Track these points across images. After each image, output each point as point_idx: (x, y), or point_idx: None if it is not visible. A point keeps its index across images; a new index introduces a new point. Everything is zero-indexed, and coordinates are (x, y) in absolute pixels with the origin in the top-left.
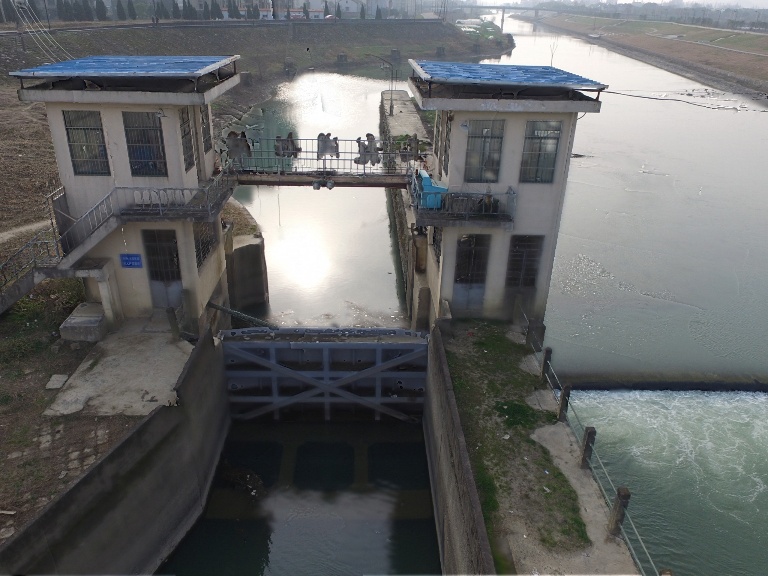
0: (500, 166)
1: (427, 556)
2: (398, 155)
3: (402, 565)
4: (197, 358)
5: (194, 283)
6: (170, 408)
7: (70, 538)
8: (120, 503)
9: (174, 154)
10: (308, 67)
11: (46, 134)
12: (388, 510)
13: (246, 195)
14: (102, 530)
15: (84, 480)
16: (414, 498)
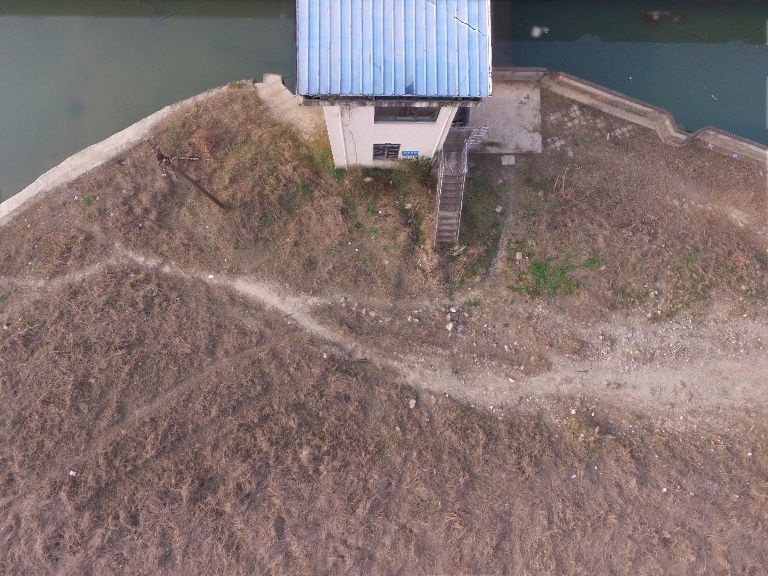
0: None
1: (531, 4)
2: None
3: (539, 15)
4: None
5: None
6: None
7: None
8: None
9: None
10: None
11: None
12: (507, 20)
13: None
14: None
15: None
16: (496, 7)
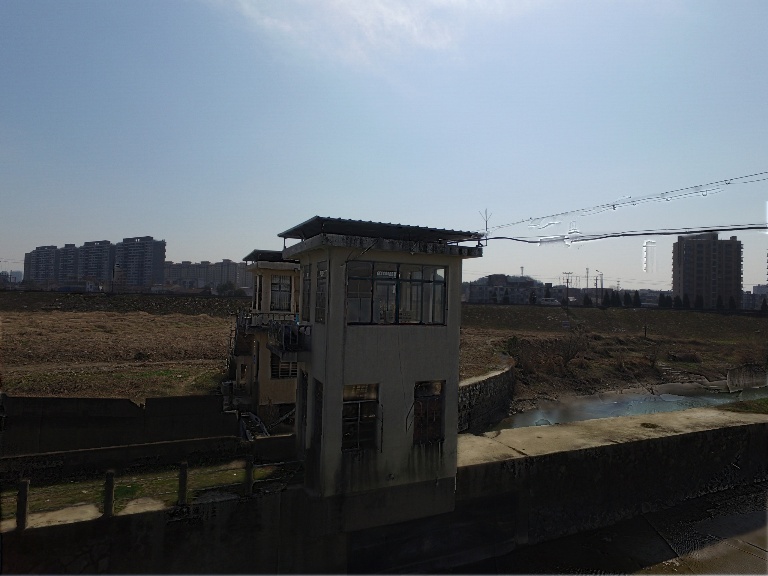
0: (310, 306)
1: None
2: (713, 407)
3: None
4: (184, 399)
5: (260, 379)
6: (133, 404)
7: (51, 420)
8: (83, 428)
9: (262, 297)
10: (756, 329)
11: (468, 345)
12: None
13: (570, 416)
14: (68, 433)
15: (69, 399)
16: None
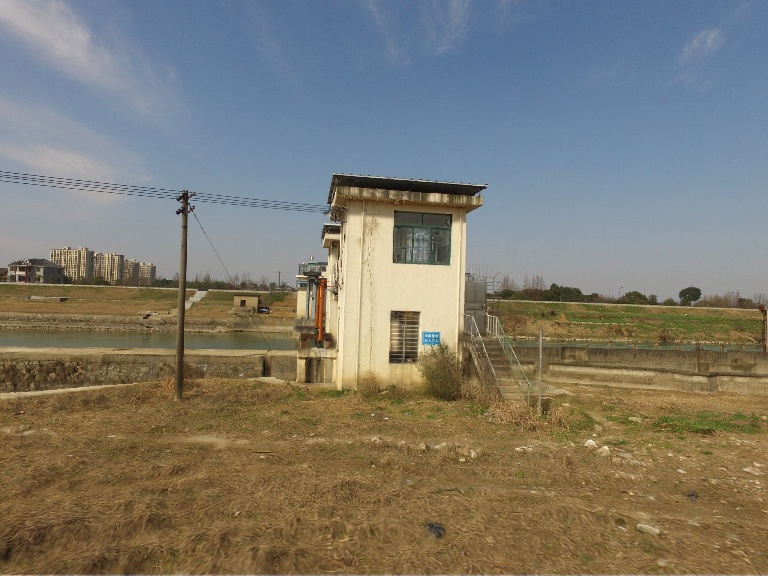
0: None
1: None
2: None
3: None
4: None
5: None
6: None
7: None
8: None
9: None
10: None
11: None
12: None
13: None
14: None
15: None
16: None
